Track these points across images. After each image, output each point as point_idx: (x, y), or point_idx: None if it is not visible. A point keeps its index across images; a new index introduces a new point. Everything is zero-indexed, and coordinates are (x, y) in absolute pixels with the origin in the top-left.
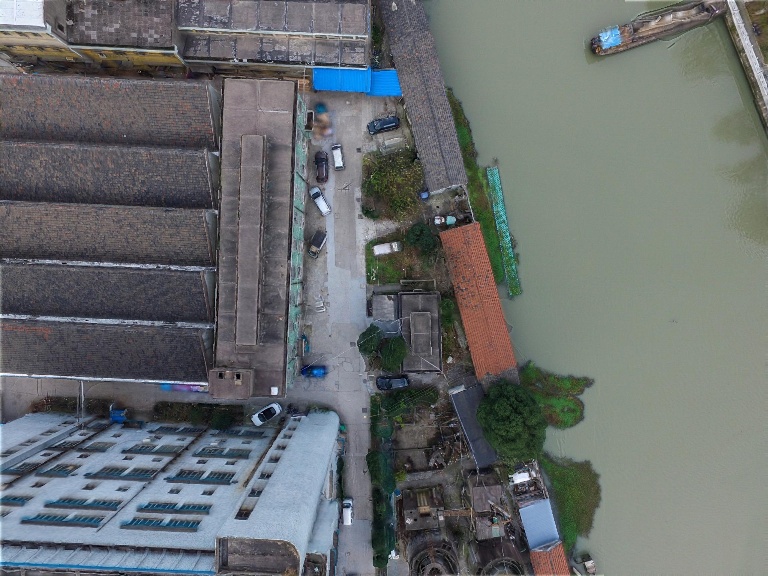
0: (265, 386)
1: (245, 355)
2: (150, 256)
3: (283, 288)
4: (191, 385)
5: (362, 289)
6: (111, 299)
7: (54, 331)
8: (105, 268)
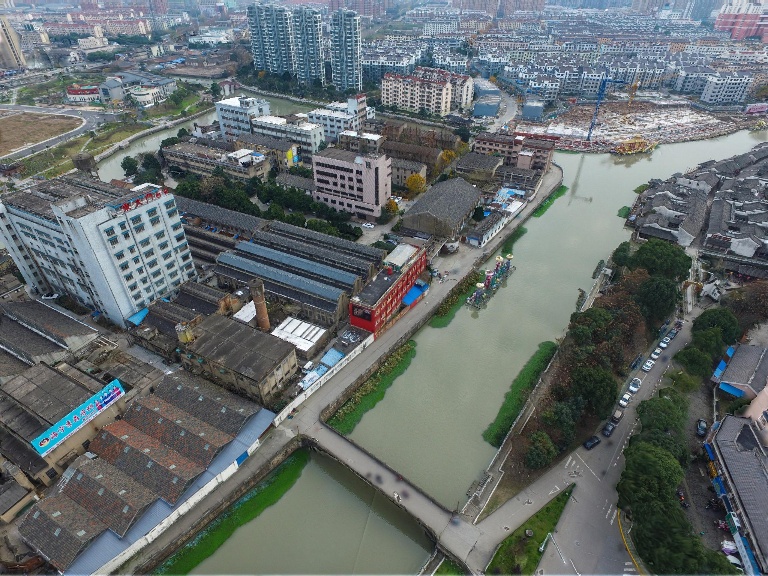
0: None
1: None
2: None
3: None
4: None
5: None
6: None
7: None
8: None
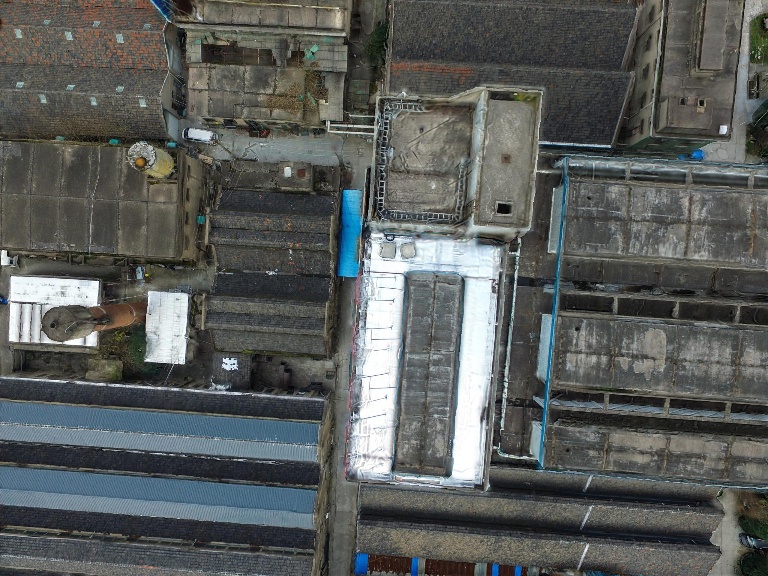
0: (713, 125)
1: (693, 90)
2: (562, 4)
3: (739, 17)
4: (590, 148)
5: (743, 69)
6: (523, 47)
7: (474, 72)
8: (533, 4)
